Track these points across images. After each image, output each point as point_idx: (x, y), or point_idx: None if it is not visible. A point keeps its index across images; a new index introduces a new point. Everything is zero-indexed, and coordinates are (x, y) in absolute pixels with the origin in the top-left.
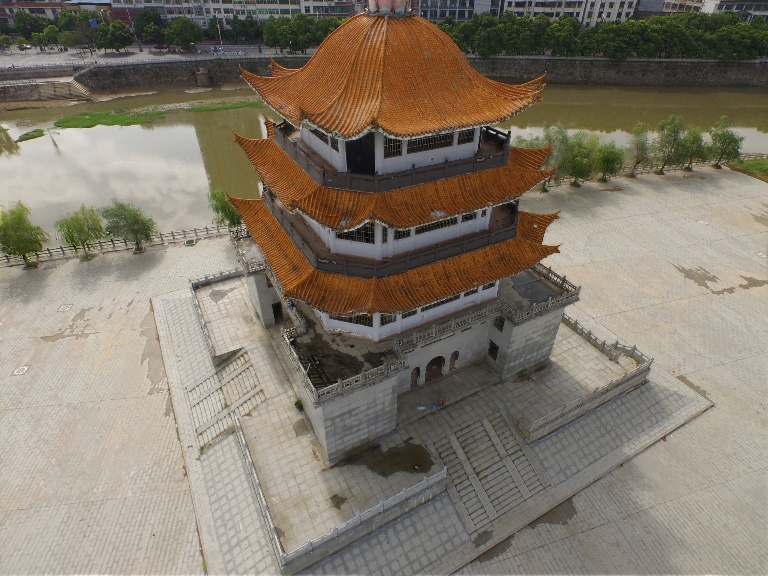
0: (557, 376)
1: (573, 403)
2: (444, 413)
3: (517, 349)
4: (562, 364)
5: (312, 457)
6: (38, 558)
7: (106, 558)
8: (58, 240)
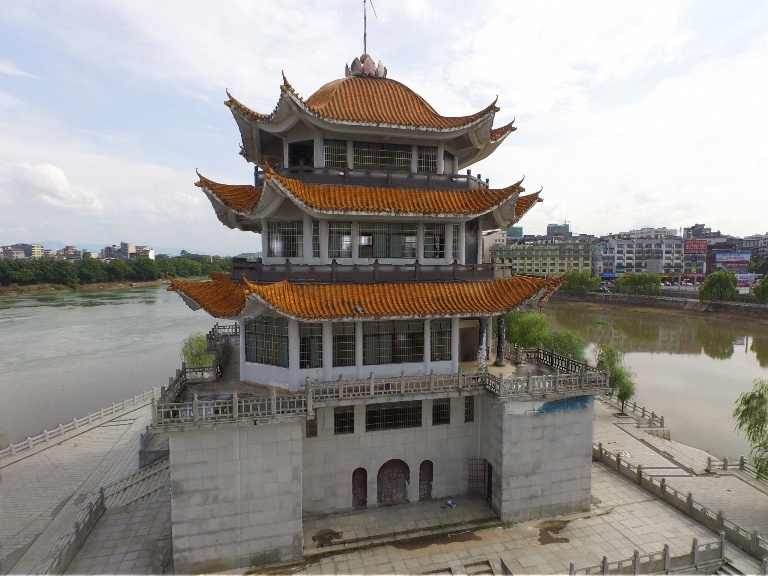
0: (132, 571)
1: (68, 545)
2: None
3: None
4: None
5: None
6: None
7: None
8: None
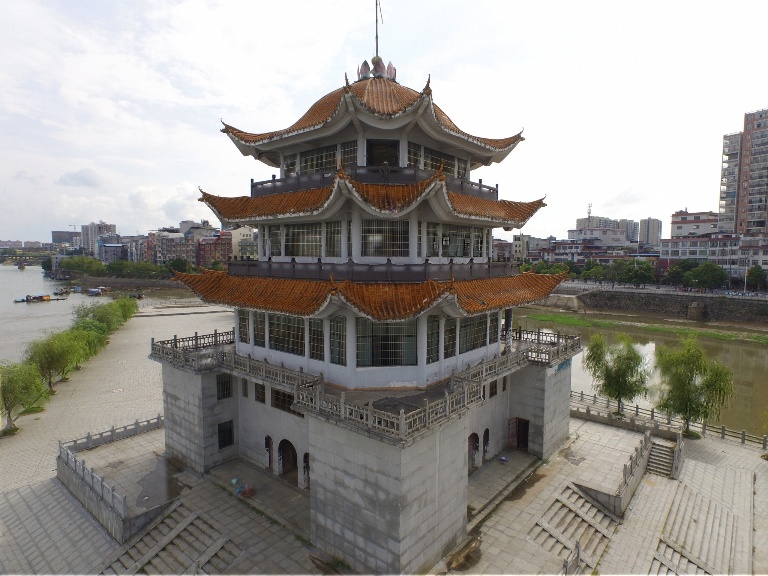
0: None
1: None
2: (232, 502)
3: (324, 487)
4: None
5: None
6: (127, 413)
7: None
8: None
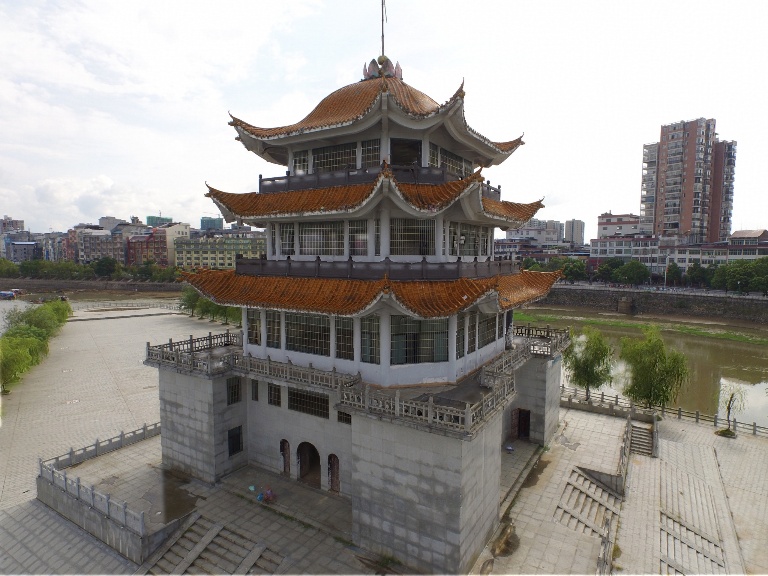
0: None
1: None
2: (256, 510)
3: (370, 486)
4: None
5: None
6: None
7: (88, 442)
8: None
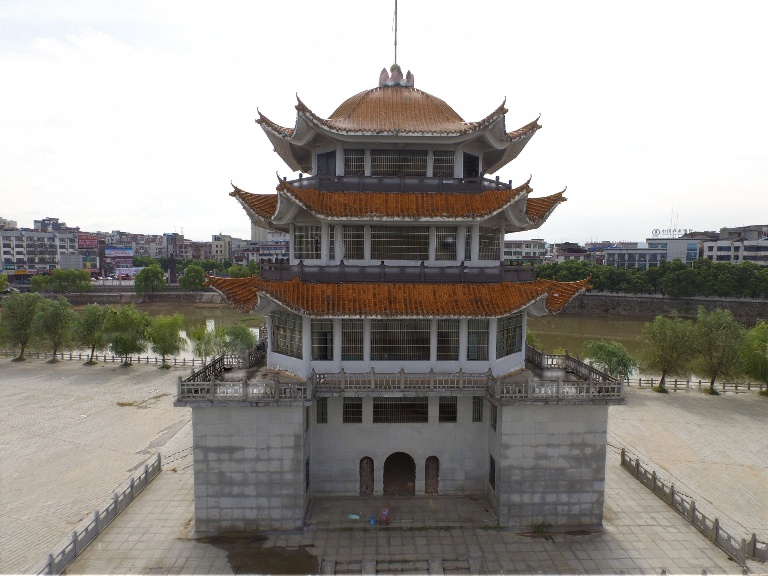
0: (603, 549)
1: None
2: (382, 535)
3: (520, 467)
4: (623, 538)
5: (183, 522)
6: None
7: None
8: (194, 353)
